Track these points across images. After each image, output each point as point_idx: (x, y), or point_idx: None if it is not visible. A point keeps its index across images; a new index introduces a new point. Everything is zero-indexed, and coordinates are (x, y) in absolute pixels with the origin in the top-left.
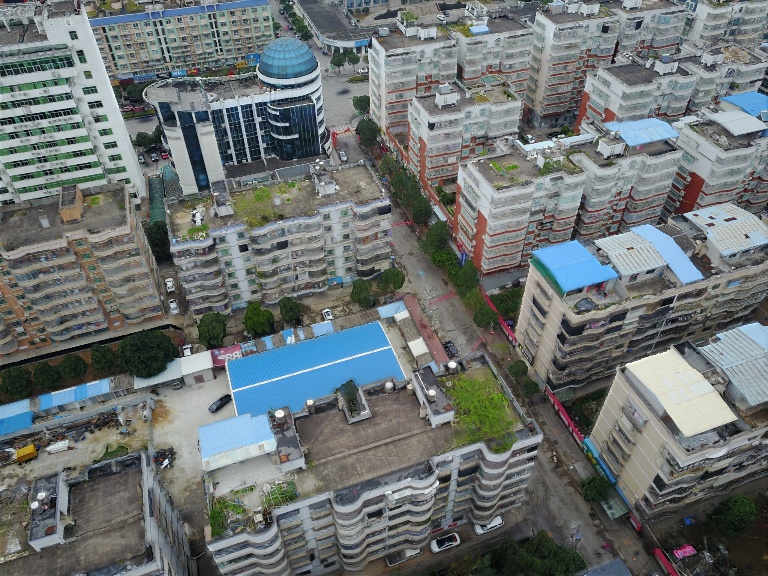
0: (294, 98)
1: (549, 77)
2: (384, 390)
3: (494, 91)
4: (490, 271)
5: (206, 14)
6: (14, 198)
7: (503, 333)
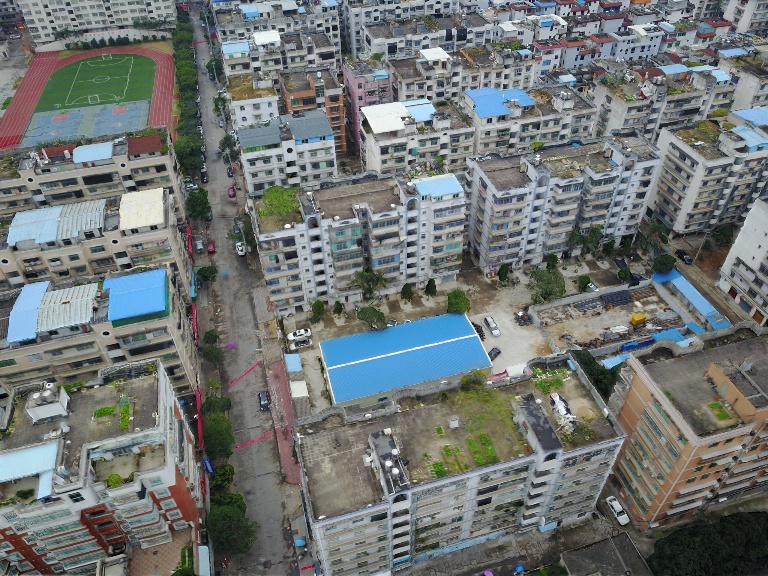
0: None
1: None
2: None
3: None
4: None
5: None
6: None
7: None
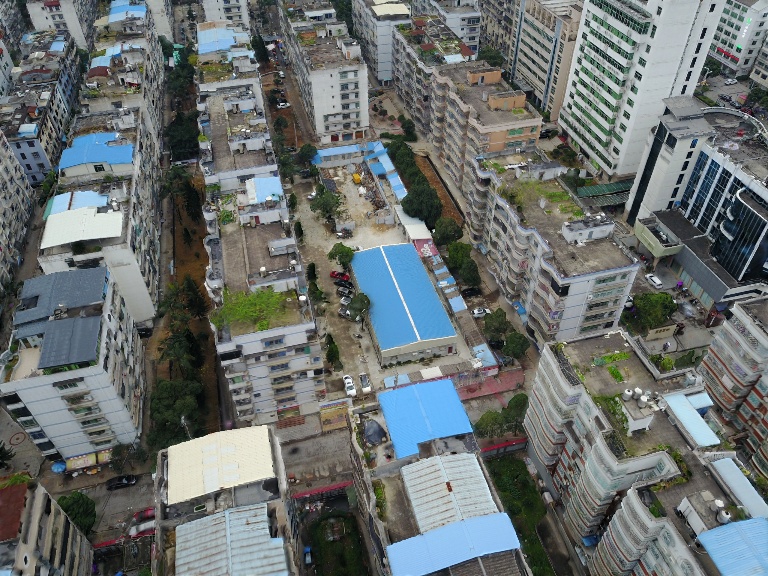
0: None
1: None
2: None
3: None
4: None
5: None
6: None
7: None
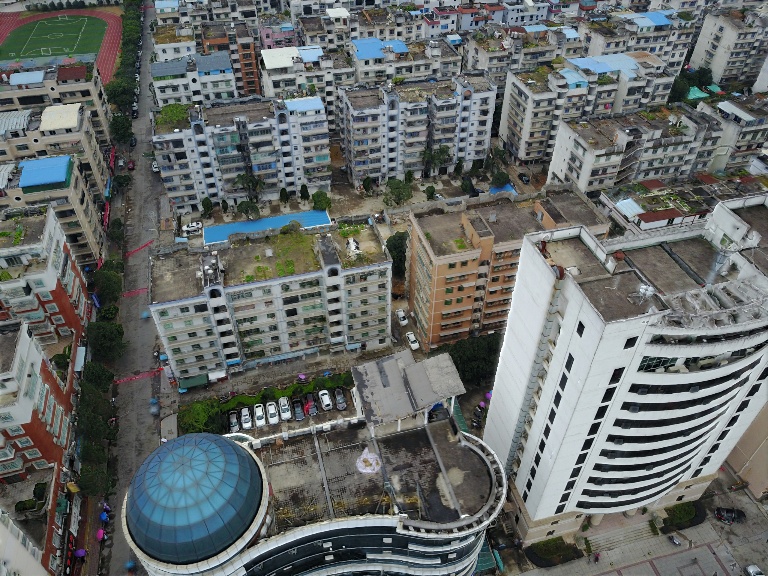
0: None
1: None
2: None
3: None
4: None
5: None
6: None
7: None
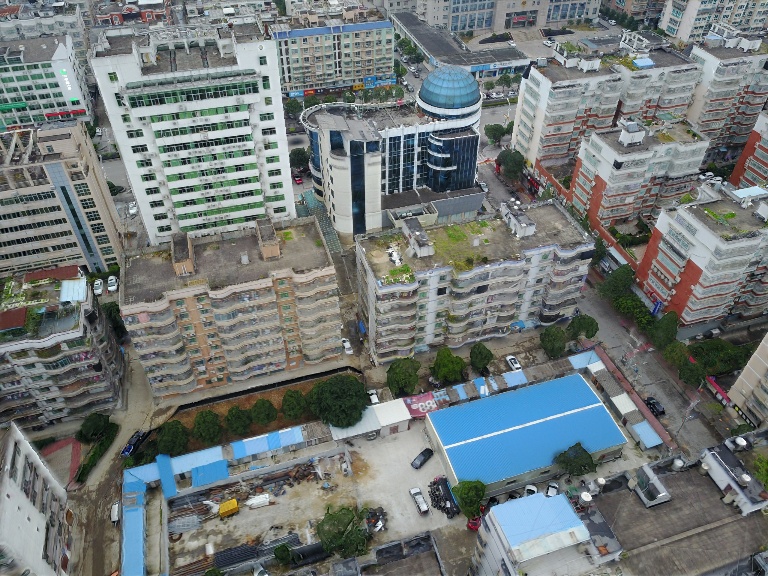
0: (456, 129)
1: (704, 113)
2: (670, 467)
3: (675, 129)
4: (691, 323)
5: (331, 35)
6: (171, 224)
7: (707, 390)
